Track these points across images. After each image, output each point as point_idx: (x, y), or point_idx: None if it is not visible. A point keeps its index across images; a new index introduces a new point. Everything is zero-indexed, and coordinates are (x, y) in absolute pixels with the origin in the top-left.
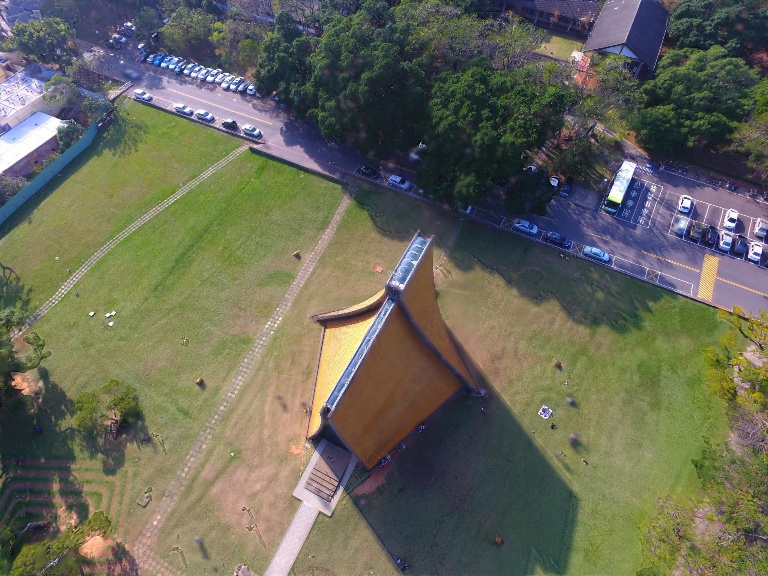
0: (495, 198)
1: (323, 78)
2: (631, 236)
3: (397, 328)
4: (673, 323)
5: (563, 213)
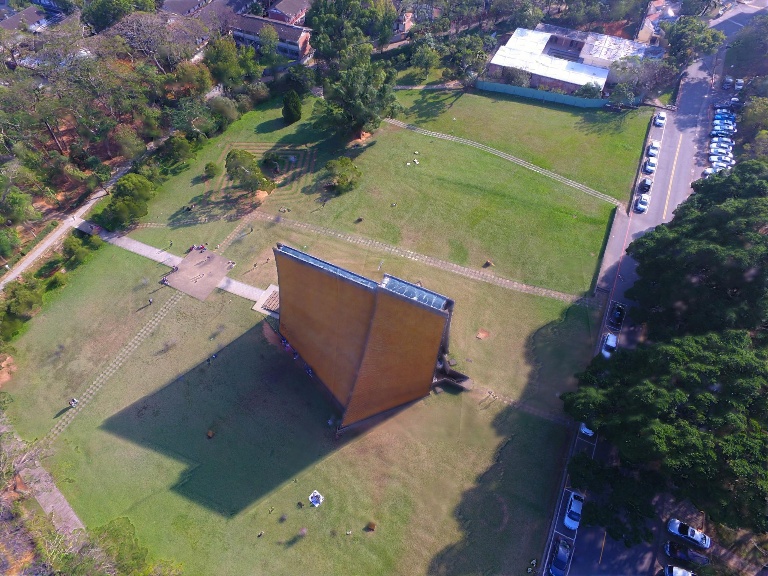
0: None
1: None
2: None
3: (365, 308)
4: None
5: None
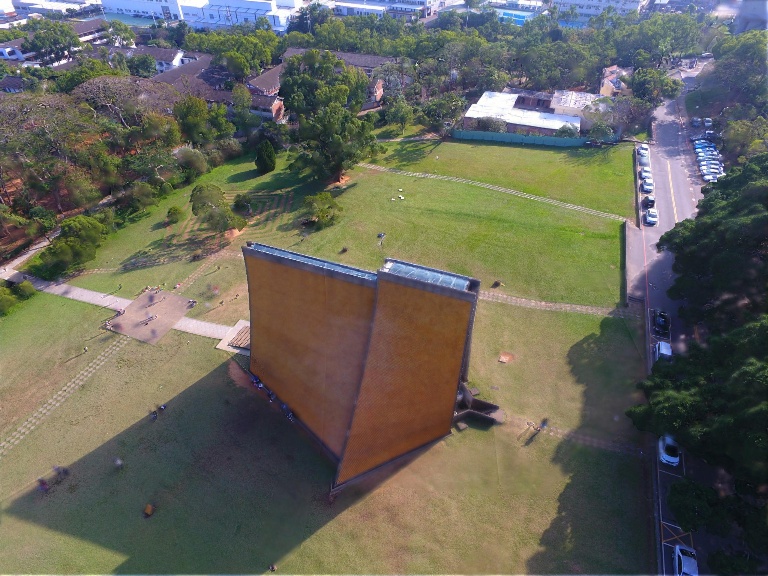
0: None
1: None
2: None
3: (362, 313)
4: None
5: None
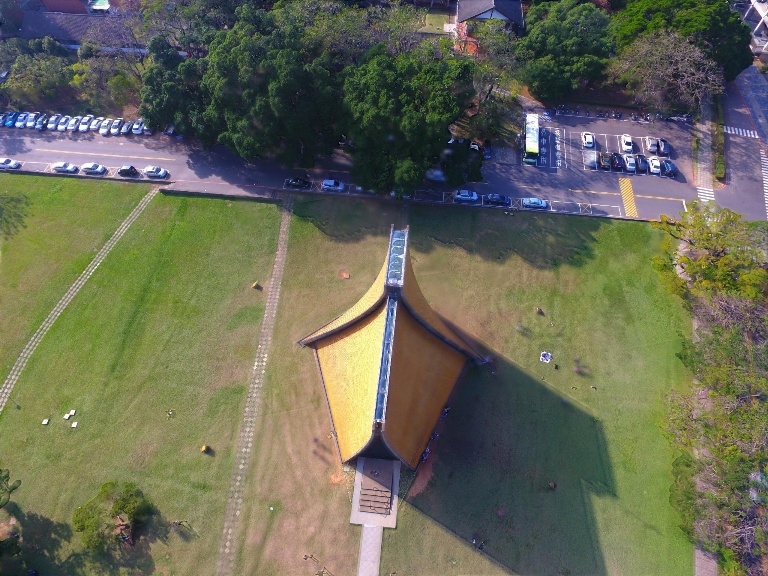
0: (428, 177)
1: (224, 99)
2: (556, 179)
3: (402, 324)
4: (616, 244)
5: (492, 174)
